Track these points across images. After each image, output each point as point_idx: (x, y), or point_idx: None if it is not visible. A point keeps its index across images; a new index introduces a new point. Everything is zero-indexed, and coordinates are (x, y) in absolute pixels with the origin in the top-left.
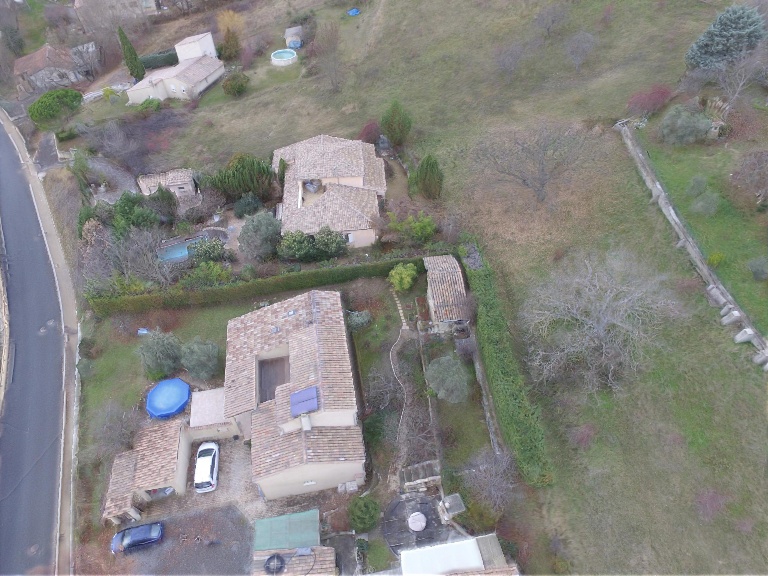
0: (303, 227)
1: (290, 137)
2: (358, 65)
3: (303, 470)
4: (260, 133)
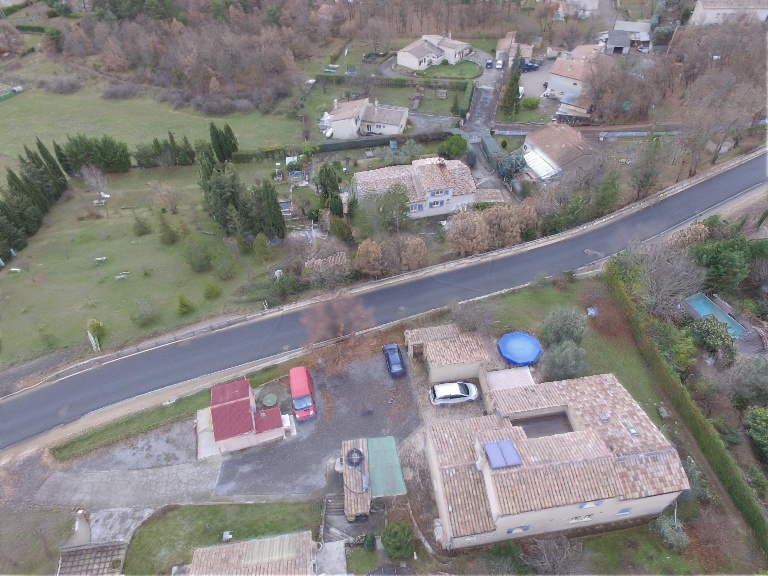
0: None
1: None
2: None
3: None
4: None
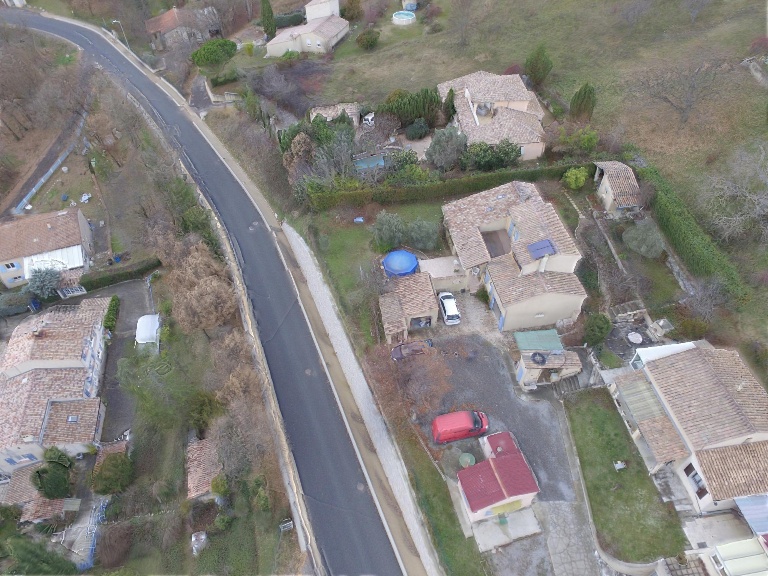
0: (485, 140)
1: (432, 81)
2: (479, 23)
3: (543, 299)
4: (402, 78)
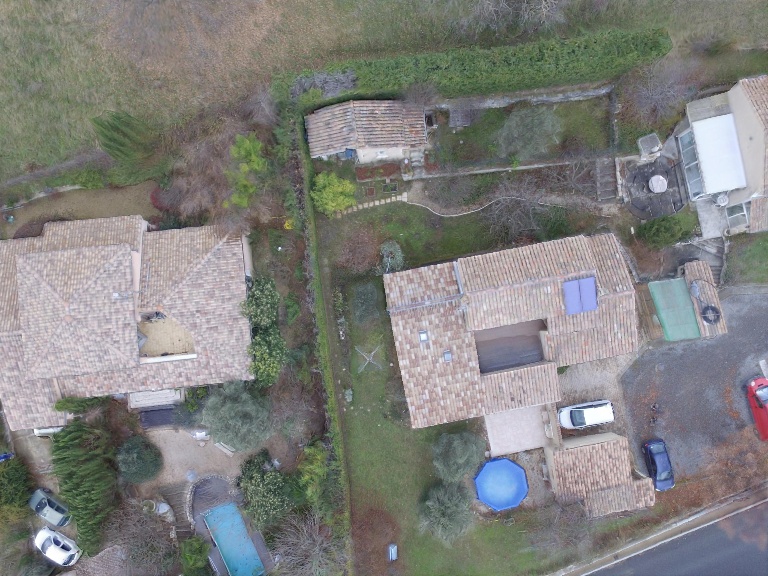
0: (239, 345)
1: None
2: None
3: None
4: None
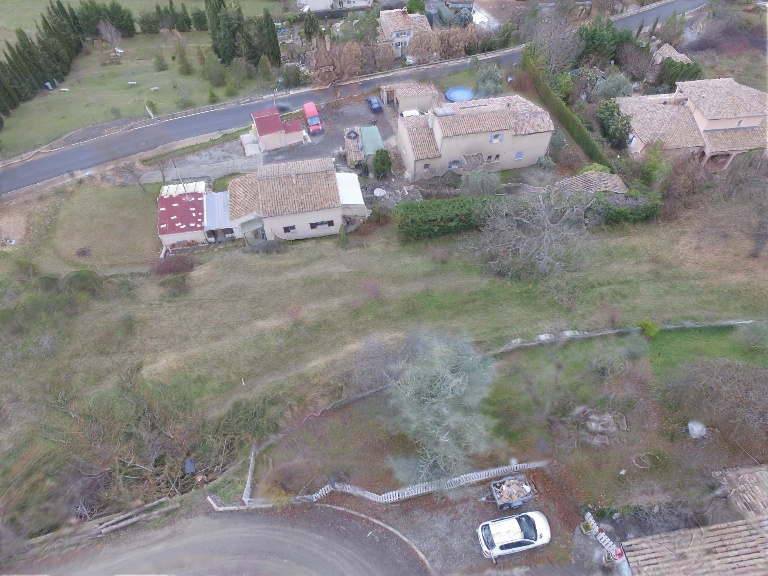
0: (626, 106)
1: None
2: None
3: None
4: None
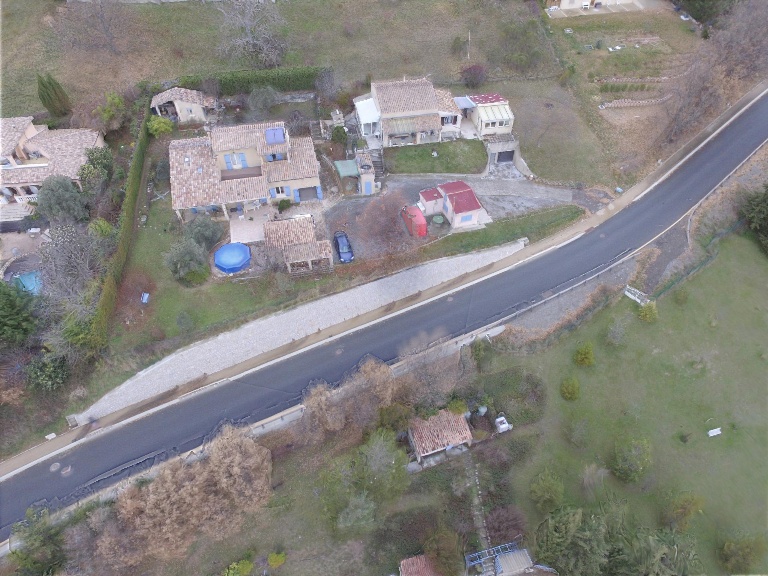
0: (76, 165)
1: None
2: None
3: None
4: None
